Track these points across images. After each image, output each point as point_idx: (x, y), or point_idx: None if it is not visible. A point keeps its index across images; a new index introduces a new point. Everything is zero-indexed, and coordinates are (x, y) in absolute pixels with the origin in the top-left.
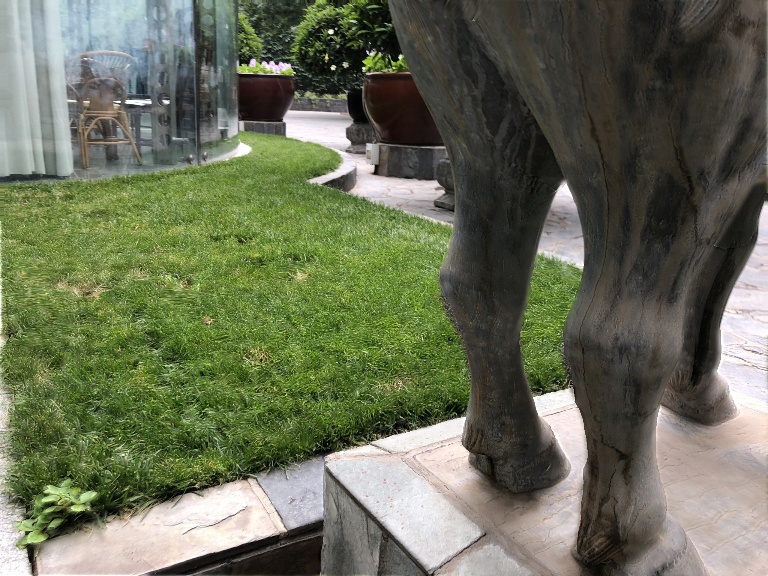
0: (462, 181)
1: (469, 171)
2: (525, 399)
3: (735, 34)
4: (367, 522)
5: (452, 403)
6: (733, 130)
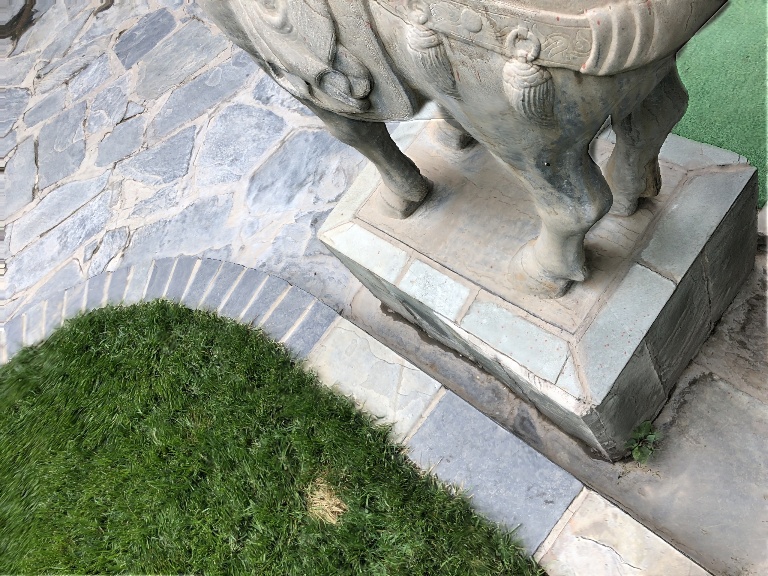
0: (580, 162)
1: (583, 150)
2: None
3: None
4: None
5: (357, 418)
6: None
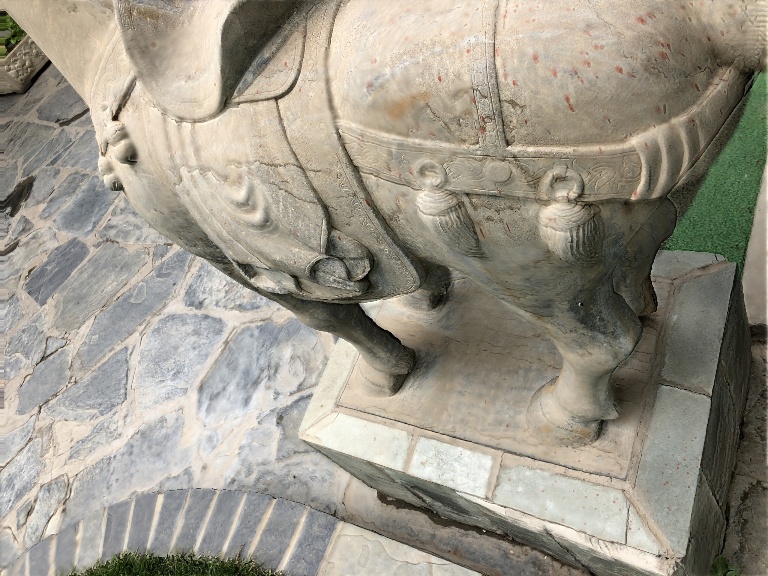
0: (609, 294)
1: None
2: None
3: None
4: (697, 486)
5: None
6: None
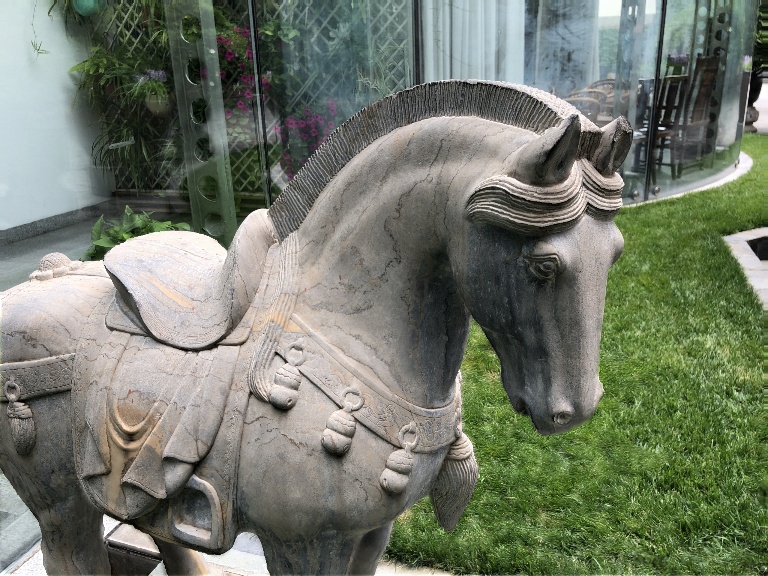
0: None
1: None
2: (174, 565)
3: (0, 457)
4: None
5: (387, 546)
6: (28, 492)
